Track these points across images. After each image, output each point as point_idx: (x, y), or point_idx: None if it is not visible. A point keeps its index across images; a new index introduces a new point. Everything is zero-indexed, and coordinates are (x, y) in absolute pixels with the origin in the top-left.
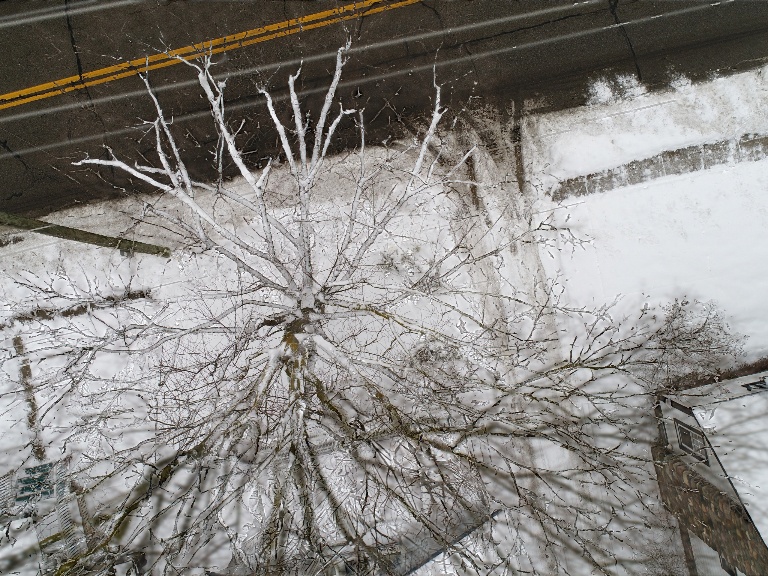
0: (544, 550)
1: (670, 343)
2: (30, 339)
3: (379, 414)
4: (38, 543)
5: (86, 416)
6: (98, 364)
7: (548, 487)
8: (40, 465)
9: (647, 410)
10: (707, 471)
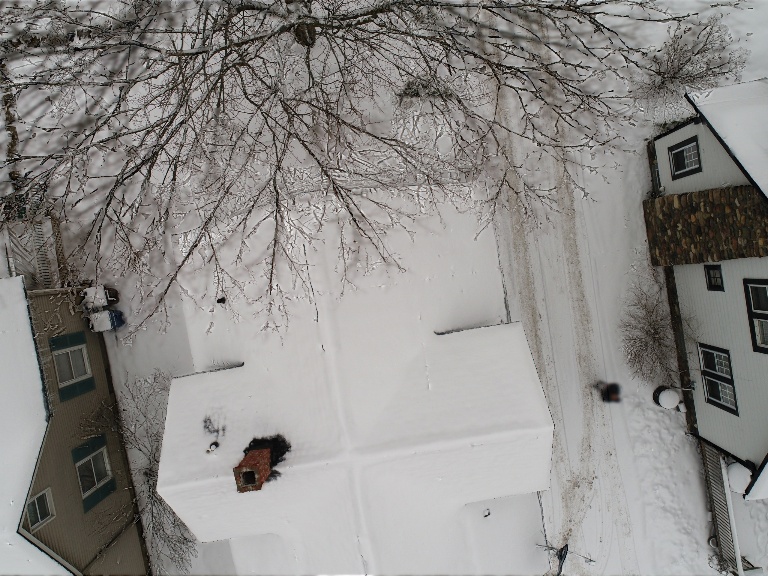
0: (526, 304)
1: (669, 77)
2: (14, 65)
3: (361, 52)
4: (6, 225)
5: (60, 62)
6: (82, 92)
7: (534, 238)
8: (17, 195)
9: (641, 161)
10: (699, 179)
